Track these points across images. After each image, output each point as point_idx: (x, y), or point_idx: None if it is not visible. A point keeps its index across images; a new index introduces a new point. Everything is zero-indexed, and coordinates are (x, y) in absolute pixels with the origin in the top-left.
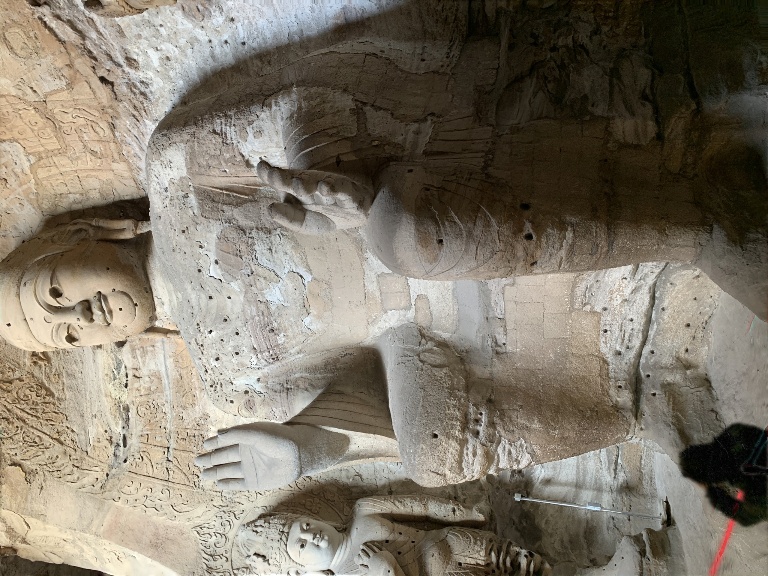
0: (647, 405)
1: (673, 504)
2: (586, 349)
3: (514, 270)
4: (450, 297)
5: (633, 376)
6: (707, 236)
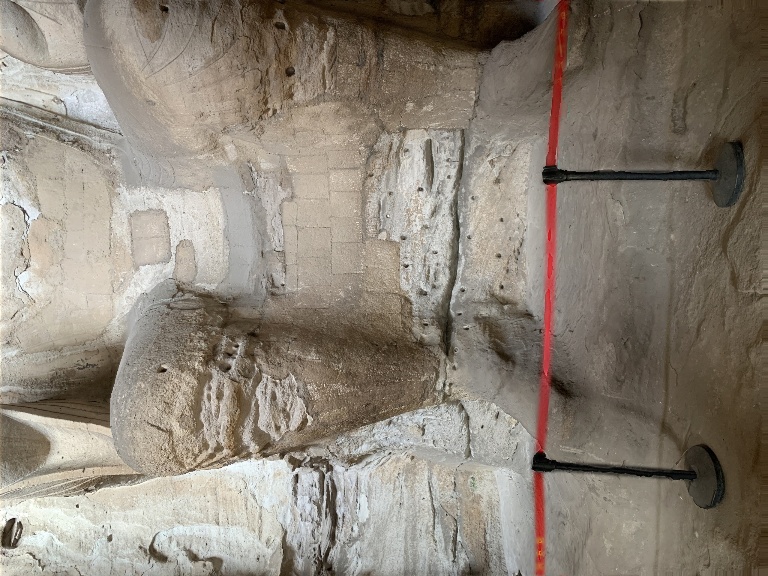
0: (459, 339)
1: (525, 565)
2: (384, 286)
3: (268, 85)
4: (220, 239)
5: (442, 318)
6: (486, 55)
